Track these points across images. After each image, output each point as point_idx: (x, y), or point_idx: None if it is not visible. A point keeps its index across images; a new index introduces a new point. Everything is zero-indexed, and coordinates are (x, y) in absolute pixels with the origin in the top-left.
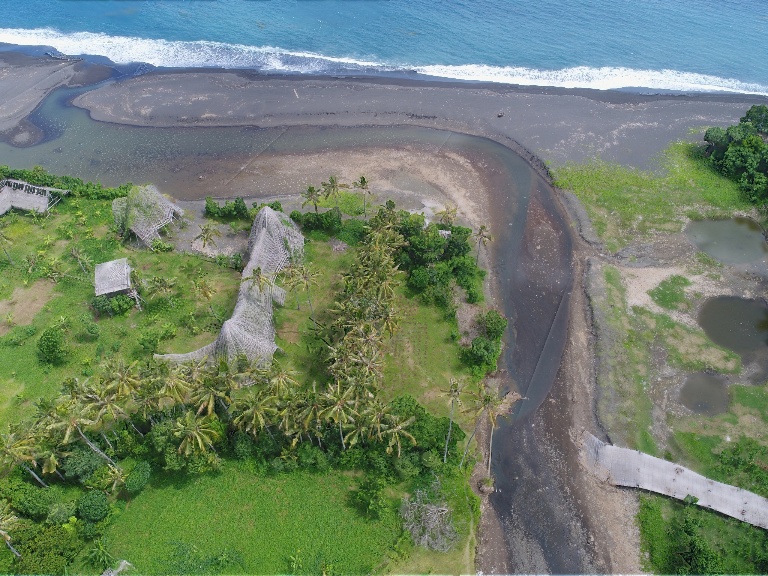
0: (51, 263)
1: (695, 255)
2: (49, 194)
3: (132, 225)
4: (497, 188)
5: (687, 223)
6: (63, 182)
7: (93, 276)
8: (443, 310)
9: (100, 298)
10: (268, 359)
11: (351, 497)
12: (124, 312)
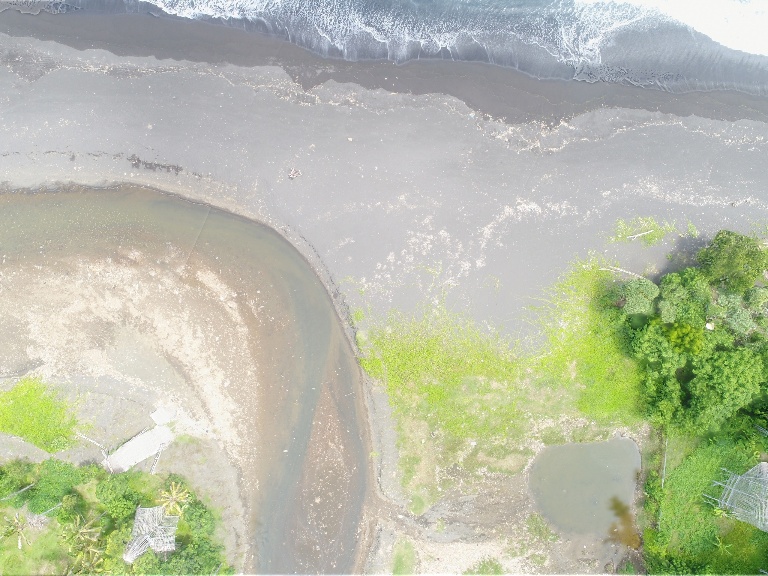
0: None
1: (527, 520)
2: None
3: None
4: (273, 367)
5: (538, 453)
6: None
7: None
8: None
9: None
10: None
11: None
12: None
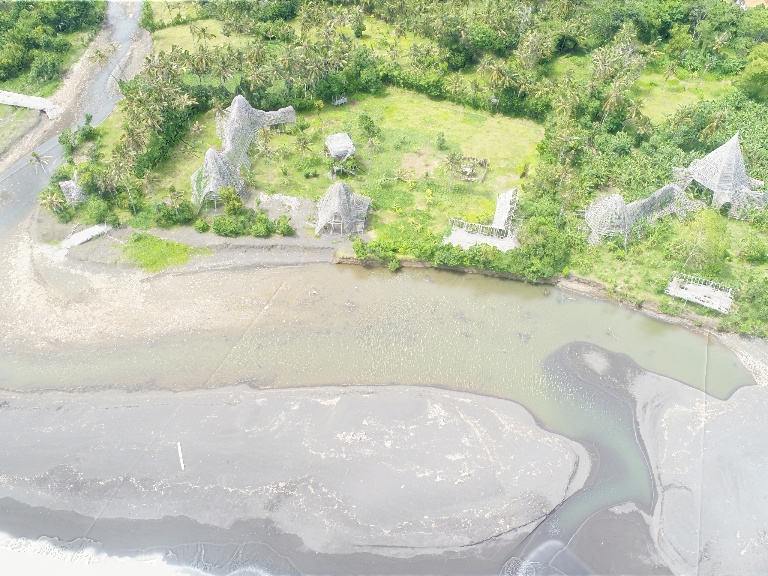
0: None
1: None
2: None
3: None
4: None
5: None
6: None
7: None
8: (99, 161)
9: None
10: None
11: None
12: None
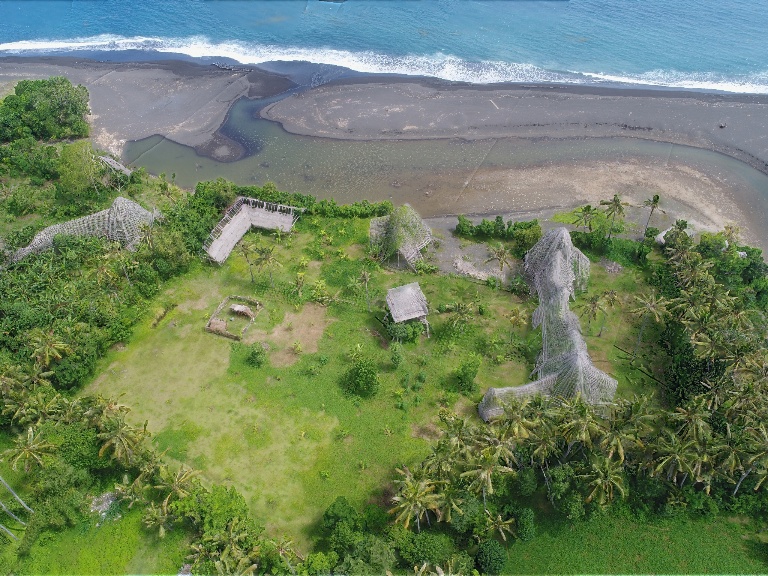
0: (318, 286)
1: None
2: (292, 212)
3: (400, 246)
4: (748, 204)
5: None
6: (295, 199)
7: (363, 300)
8: None
9: (400, 325)
10: (610, 393)
11: (750, 547)
12: (413, 339)
